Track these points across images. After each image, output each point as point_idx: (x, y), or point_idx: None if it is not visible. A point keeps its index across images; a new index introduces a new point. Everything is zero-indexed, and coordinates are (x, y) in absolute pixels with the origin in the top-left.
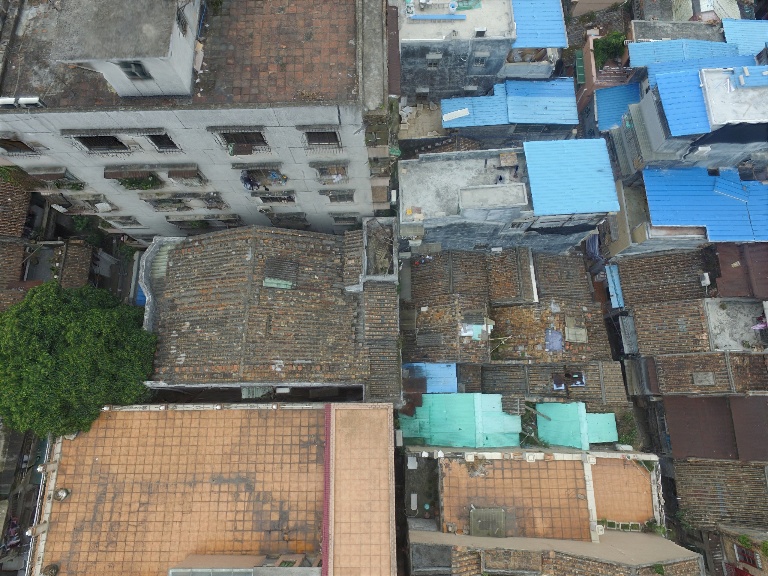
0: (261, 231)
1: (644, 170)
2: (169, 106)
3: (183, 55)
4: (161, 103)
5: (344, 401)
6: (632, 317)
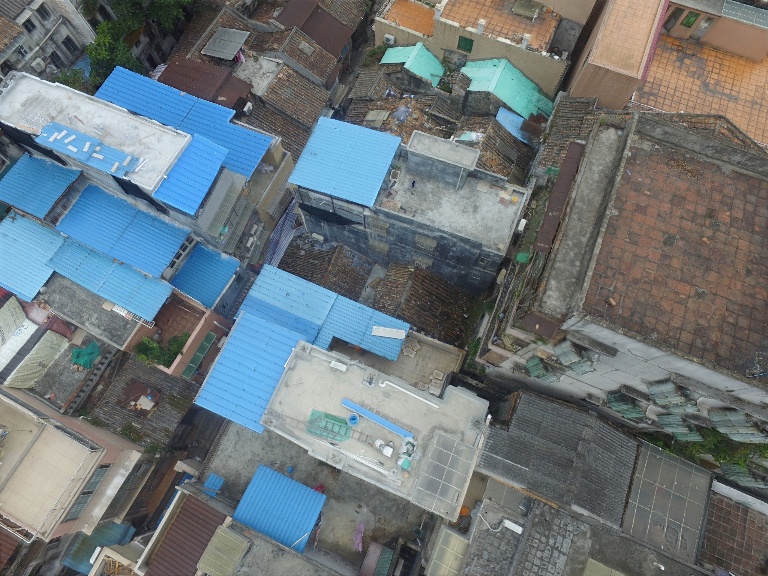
0: None
1: None
2: None
3: None
4: None
5: None
6: None
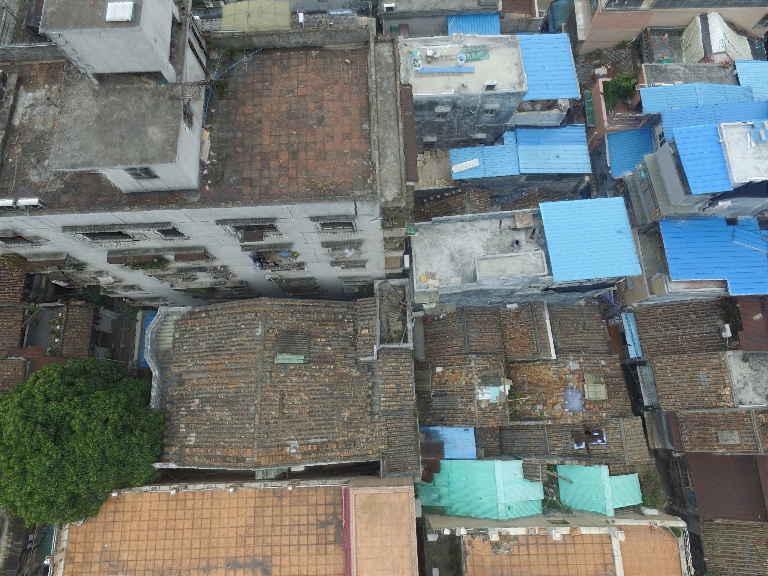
0: (271, 303)
1: (661, 221)
2: (176, 205)
3: (190, 150)
4: (167, 197)
5: (361, 474)
6: (651, 367)
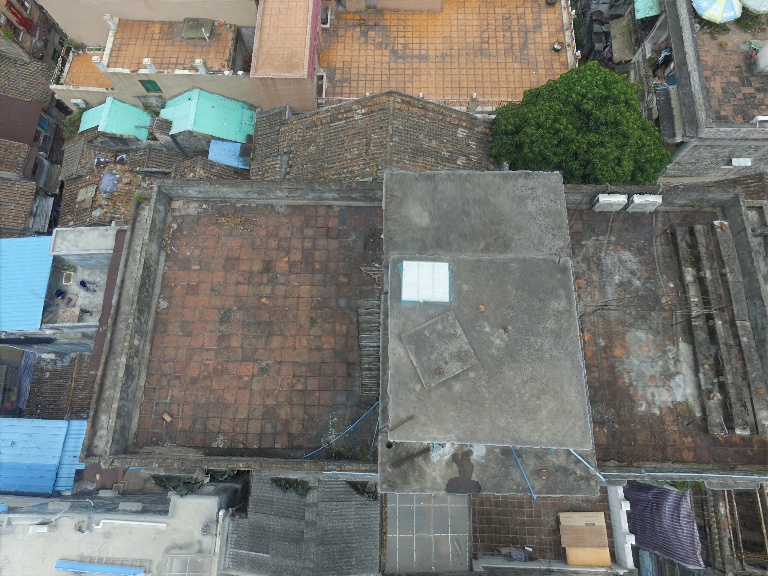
0: None
1: None
2: None
3: None
4: None
5: None
6: None
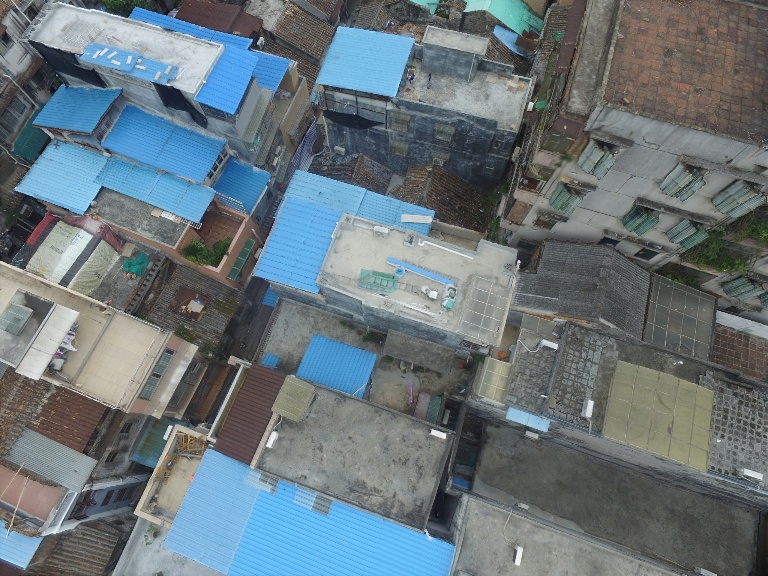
0: None
1: None
2: None
3: None
4: None
5: None
6: None
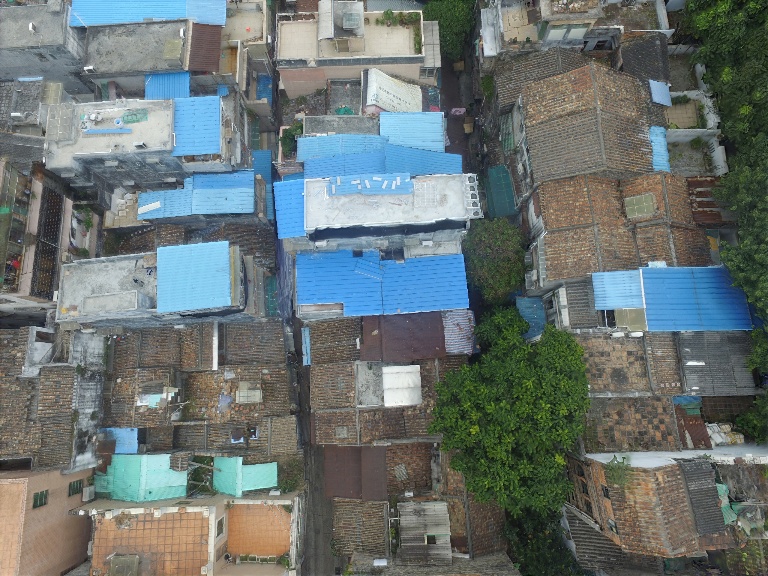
0: None
1: (297, 255)
2: None
3: None
4: None
5: None
6: None
